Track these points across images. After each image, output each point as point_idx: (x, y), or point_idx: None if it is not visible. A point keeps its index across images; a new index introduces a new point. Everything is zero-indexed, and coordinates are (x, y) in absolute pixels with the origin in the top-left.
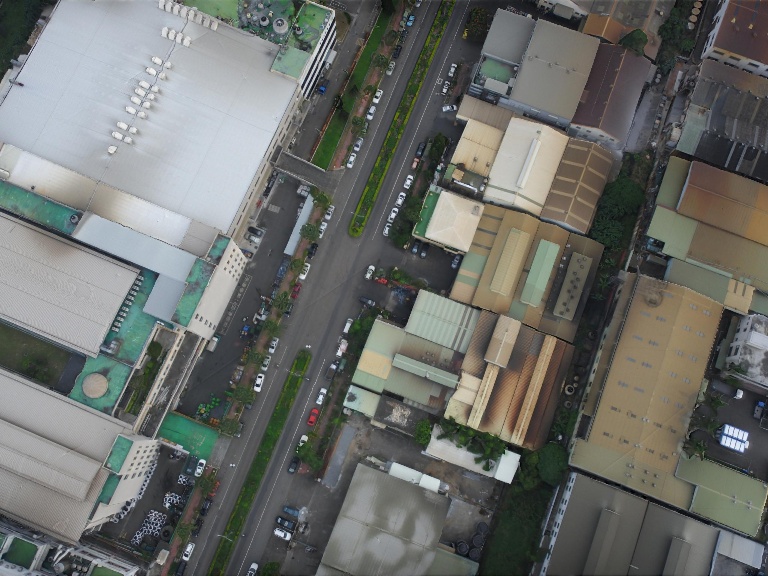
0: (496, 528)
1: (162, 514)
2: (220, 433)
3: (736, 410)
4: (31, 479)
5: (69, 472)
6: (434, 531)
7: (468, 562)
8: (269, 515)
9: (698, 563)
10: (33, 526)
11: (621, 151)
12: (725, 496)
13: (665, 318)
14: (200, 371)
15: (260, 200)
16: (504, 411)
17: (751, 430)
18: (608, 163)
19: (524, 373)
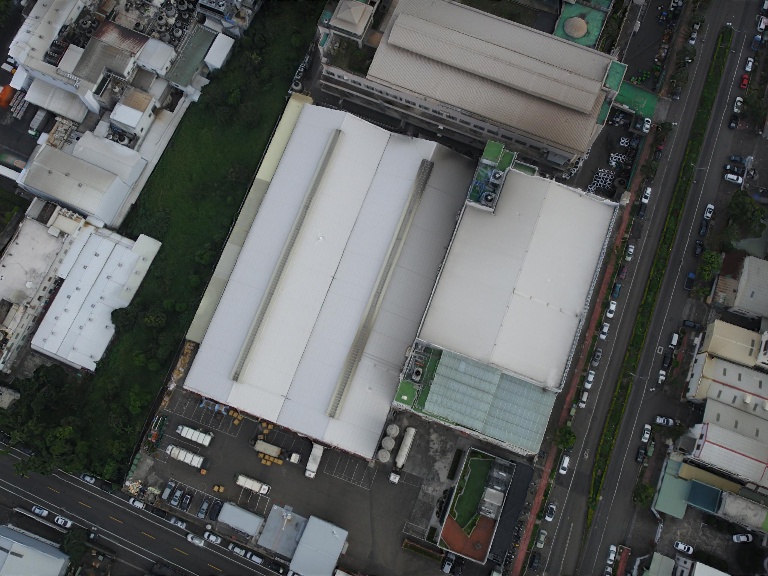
0: None
1: (610, 171)
2: (659, 97)
3: None
4: (540, 96)
5: (578, 86)
6: None
7: None
8: (716, 165)
9: None
10: (542, 140)
11: None
12: None
13: None
14: None
15: None
16: None
17: None
18: None
19: None
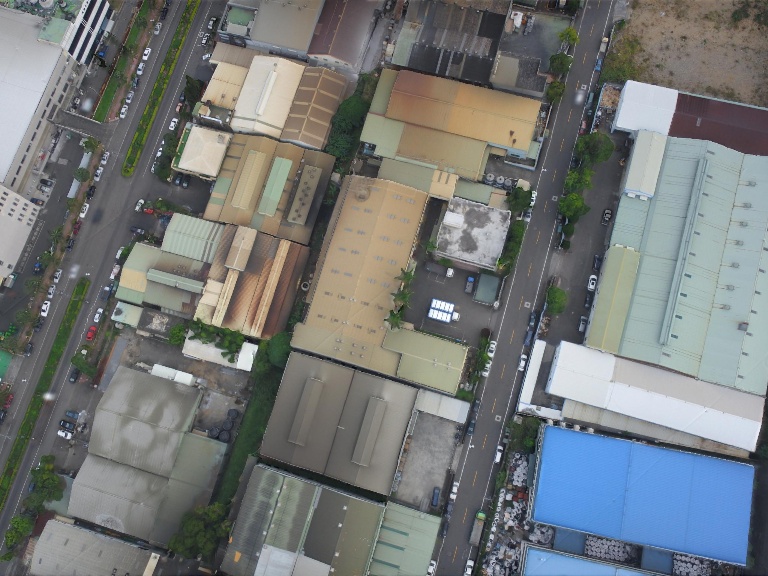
0: None
1: None
2: (14, 354)
3: (450, 288)
4: None
5: None
6: (180, 416)
7: (217, 443)
8: (55, 420)
9: (398, 419)
10: None
11: (357, 74)
12: (427, 360)
13: (371, 210)
14: (1, 305)
15: (44, 154)
16: (245, 309)
17: (464, 304)
18: (340, 85)
19: (263, 275)
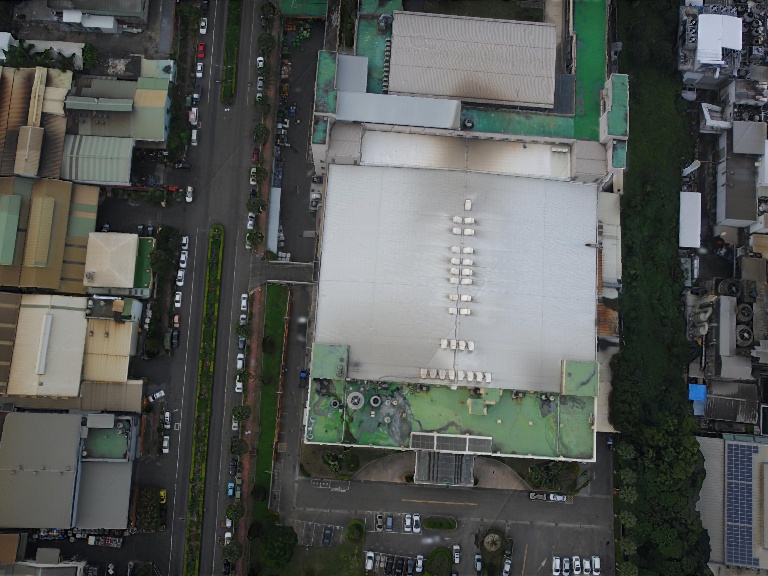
0: (5, 3)
1: None
2: None
3: None
4: None
5: None
6: None
7: None
8: None
9: None
10: None
11: None
12: None
13: None
14: None
15: None
16: (15, 92)
17: None
18: None
19: (3, 132)
